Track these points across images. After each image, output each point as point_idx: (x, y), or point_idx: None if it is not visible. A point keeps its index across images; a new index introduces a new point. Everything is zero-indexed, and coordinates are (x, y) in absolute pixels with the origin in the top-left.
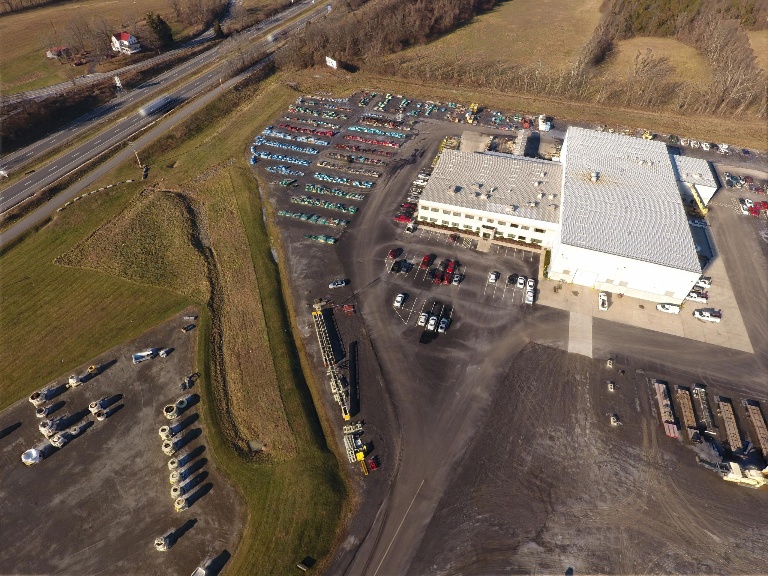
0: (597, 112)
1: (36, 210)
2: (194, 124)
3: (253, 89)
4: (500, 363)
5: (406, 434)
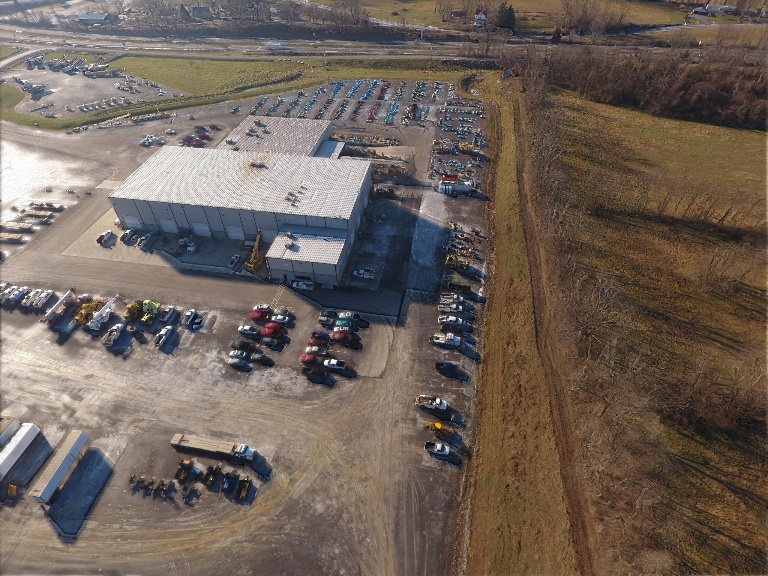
0: (515, 227)
1: (280, 56)
2: (382, 63)
3: (455, 68)
4: None
5: None
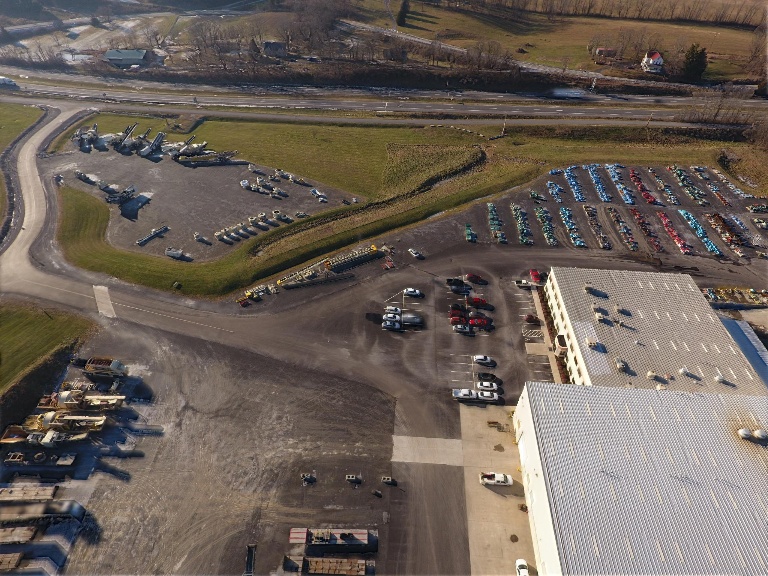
0: None
1: (427, 120)
2: (582, 132)
3: (684, 140)
4: (358, 373)
5: (271, 317)
